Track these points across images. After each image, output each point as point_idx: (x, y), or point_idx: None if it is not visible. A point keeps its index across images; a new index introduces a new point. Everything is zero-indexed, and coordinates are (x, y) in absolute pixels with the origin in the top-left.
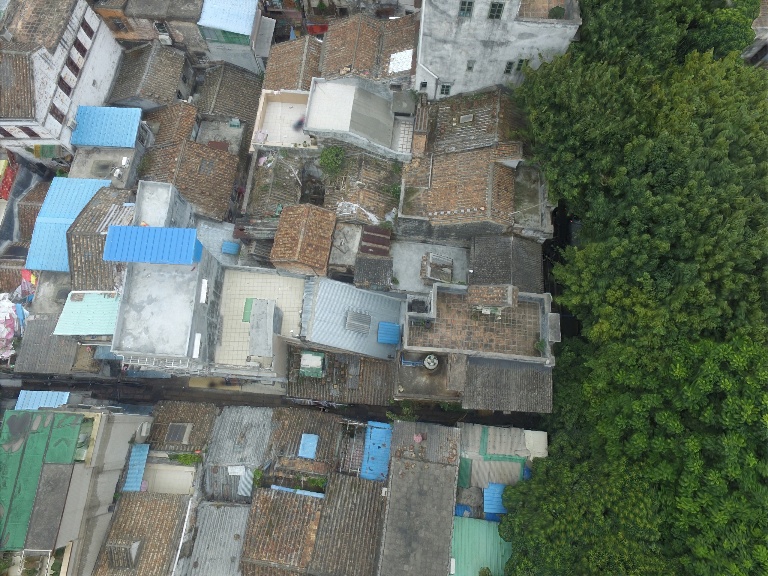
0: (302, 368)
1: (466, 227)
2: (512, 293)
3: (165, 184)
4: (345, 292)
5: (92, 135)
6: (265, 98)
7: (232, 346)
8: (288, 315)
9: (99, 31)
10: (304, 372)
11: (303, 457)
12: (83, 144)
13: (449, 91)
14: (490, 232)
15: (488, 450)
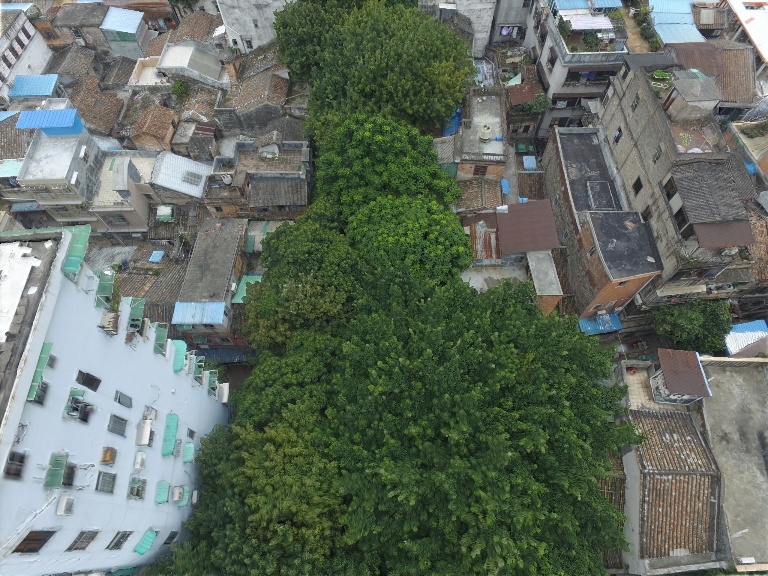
0: (158, 216)
1: (258, 113)
2: (277, 135)
3: (64, 99)
4: (185, 162)
5: (23, 90)
6: (140, 63)
7: (105, 196)
8: (145, 177)
9: (35, 36)
10: (159, 219)
11: (151, 262)
12: (17, 95)
13: (252, 45)
14: (275, 116)
15: (267, 231)
